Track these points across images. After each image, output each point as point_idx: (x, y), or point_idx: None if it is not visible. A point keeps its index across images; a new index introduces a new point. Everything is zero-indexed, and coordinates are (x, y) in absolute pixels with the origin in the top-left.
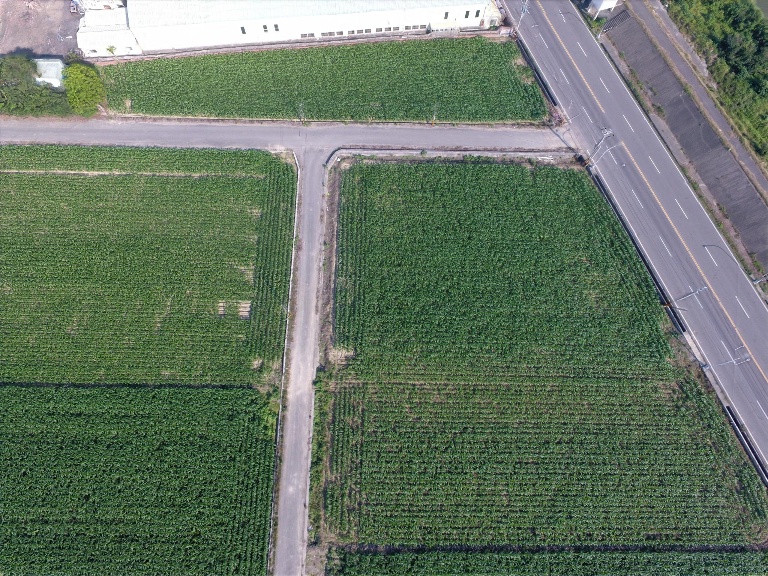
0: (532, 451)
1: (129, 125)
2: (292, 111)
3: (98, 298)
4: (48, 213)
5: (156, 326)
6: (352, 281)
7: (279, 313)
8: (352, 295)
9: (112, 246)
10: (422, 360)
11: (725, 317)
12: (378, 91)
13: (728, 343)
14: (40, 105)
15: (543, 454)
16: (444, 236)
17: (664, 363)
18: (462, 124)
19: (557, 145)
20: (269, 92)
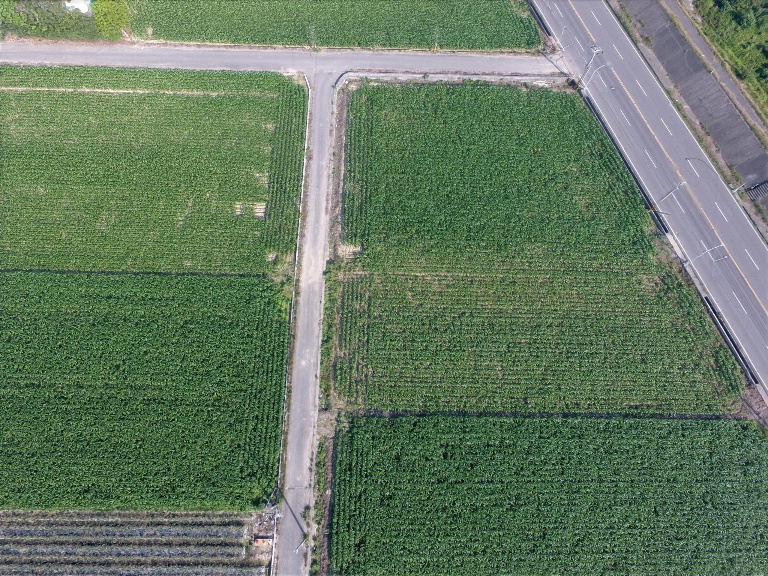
0: (525, 333)
1: (151, 50)
2: (303, 38)
3: (125, 199)
4: (77, 125)
5: (178, 224)
6: (359, 186)
7: (292, 213)
8: (359, 198)
9: (137, 154)
10: (424, 254)
11: (705, 220)
12: (383, 21)
13: (707, 242)
14: (70, 28)
15: (535, 335)
16: (445, 148)
17: (648, 259)
18: (462, 51)
19: (551, 70)
20: (282, 21)
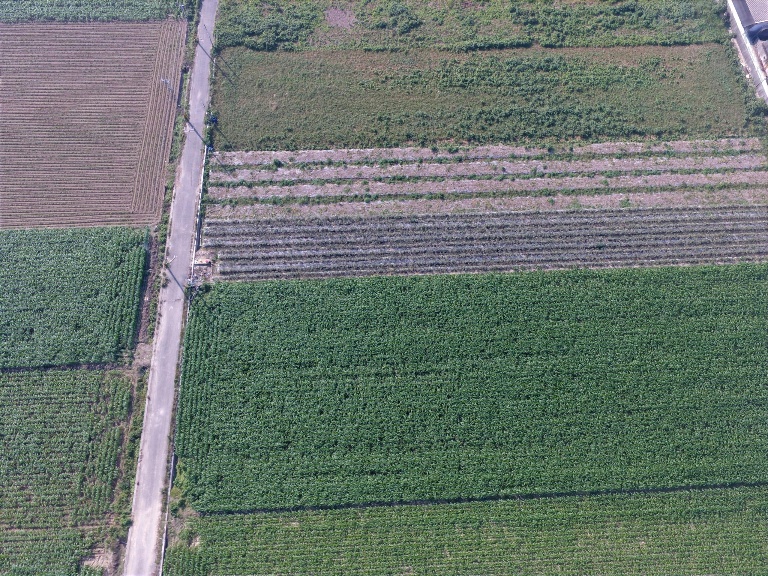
0: None
1: None
2: None
3: None
4: None
5: None
6: None
7: None
8: None
9: None
10: None
11: None
12: None
13: None
14: None
15: None
16: None
17: None
18: None
19: None
20: None
